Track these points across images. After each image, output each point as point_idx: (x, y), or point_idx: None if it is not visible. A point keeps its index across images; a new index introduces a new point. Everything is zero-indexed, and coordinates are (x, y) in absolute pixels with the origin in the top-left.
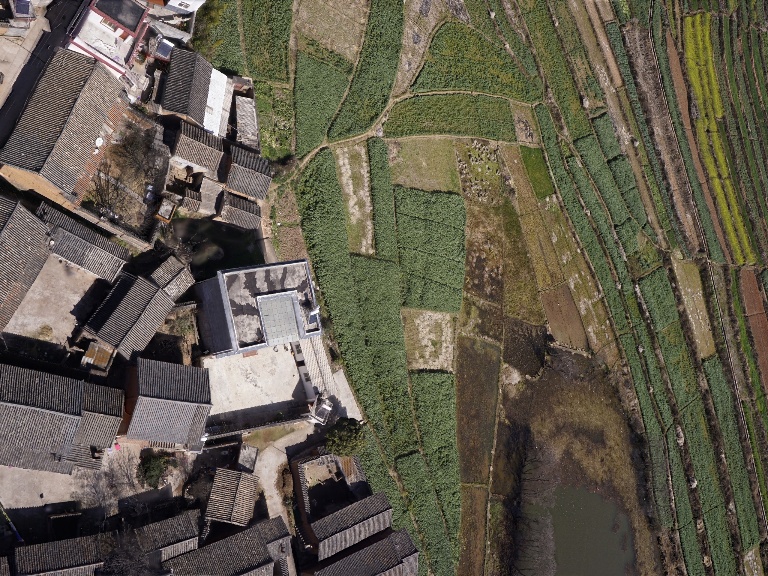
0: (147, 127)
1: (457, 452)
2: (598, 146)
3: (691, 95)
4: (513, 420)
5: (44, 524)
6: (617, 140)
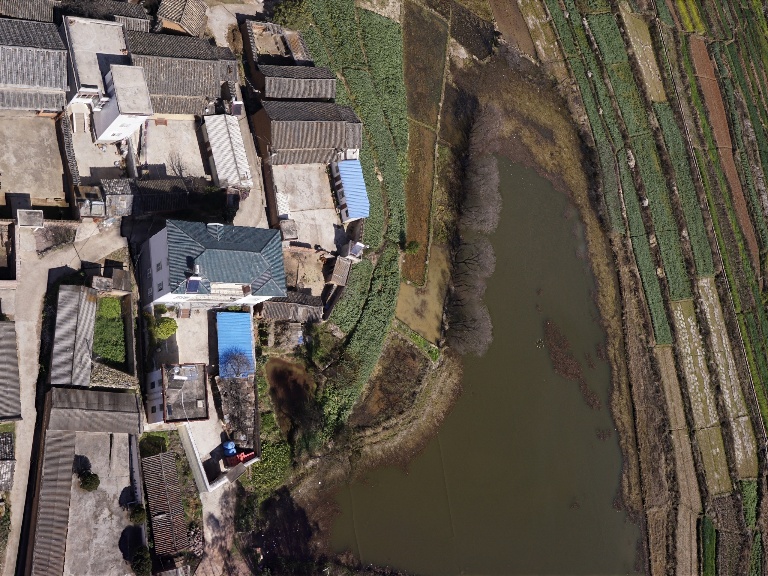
0: None
1: (404, 86)
2: None
3: None
4: (461, 87)
5: None
6: None
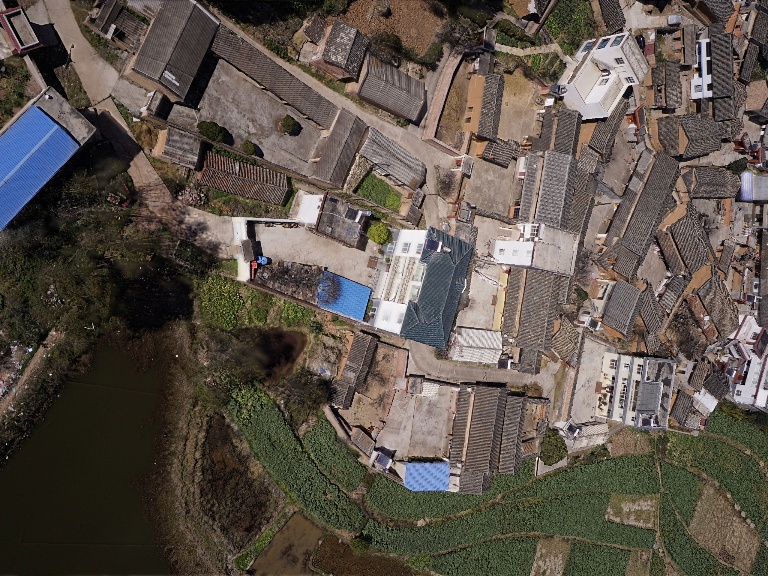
0: None
1: None
2: None
3: None
4: None
5: None
6: None
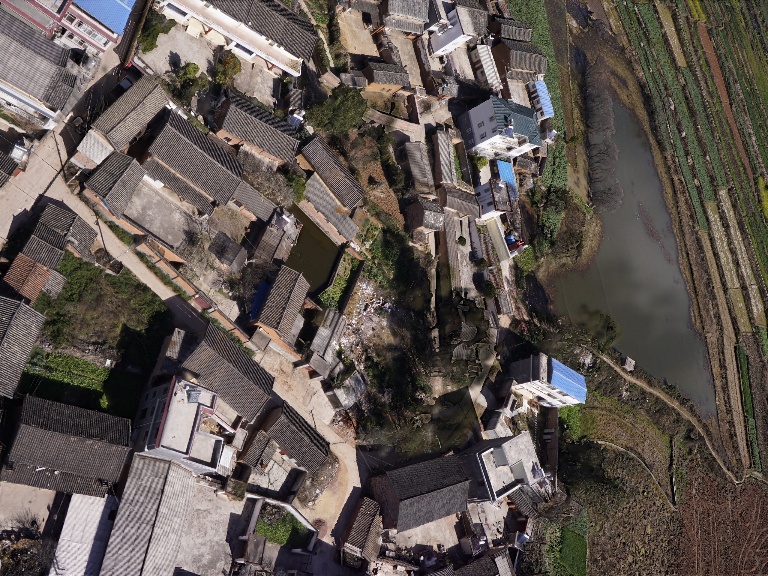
0: None
1: (551, 41)
2: None
3: None
4: (576, 45)
5: None
6: None
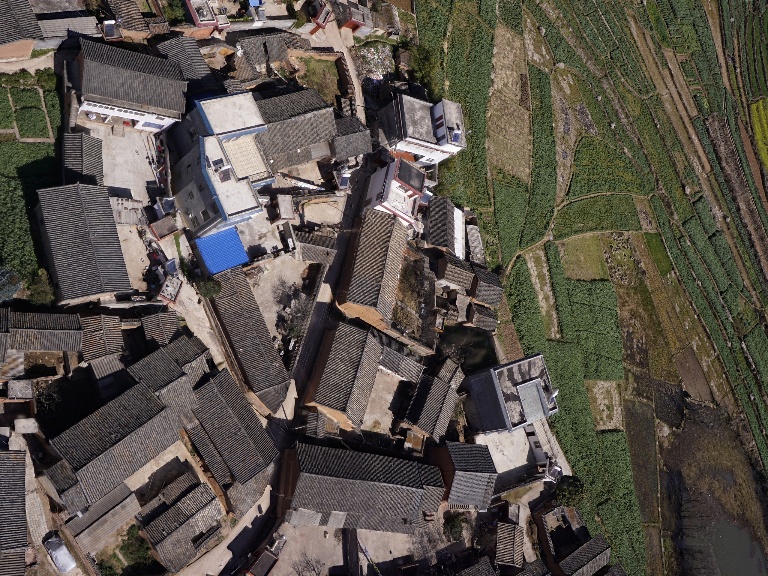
0: (415, 258)
1: (636, 497)
2: (700, 225)
3: (763, 172)
4: (669, 467)
5: (395, 574)
6: (713, 218)
